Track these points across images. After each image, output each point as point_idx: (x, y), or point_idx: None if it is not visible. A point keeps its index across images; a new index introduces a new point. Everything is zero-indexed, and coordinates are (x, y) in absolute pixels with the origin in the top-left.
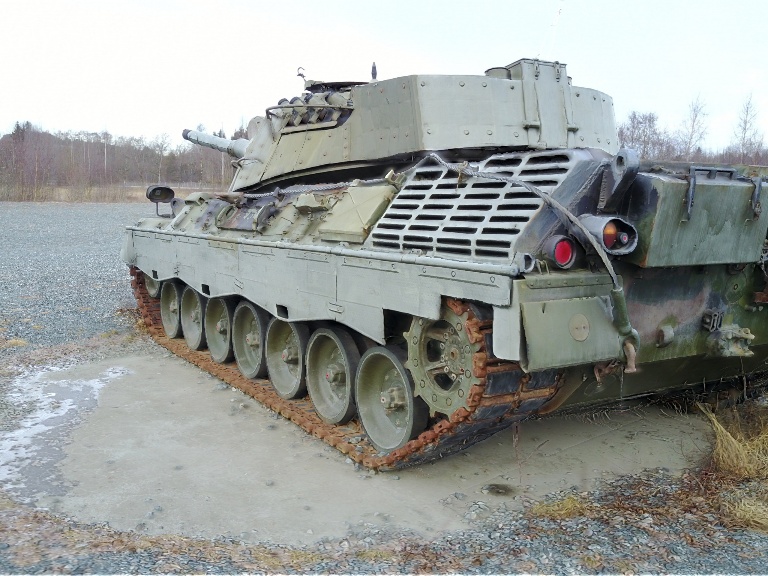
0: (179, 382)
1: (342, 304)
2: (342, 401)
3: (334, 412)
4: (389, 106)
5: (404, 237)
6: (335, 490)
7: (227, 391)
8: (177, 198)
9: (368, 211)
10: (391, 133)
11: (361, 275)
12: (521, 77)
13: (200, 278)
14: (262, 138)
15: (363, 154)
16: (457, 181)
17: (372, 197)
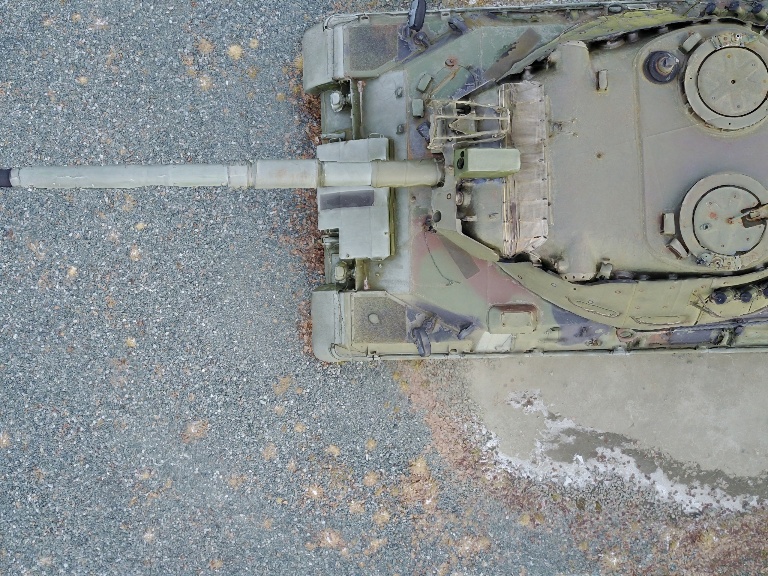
0: (588, 368)
1: None
2: None
3: None
4: None
5: None
6: None
7: None
8: None
9: None
10: None
11: None
12: None
13: None
14: None
15: None
16: None
17: None
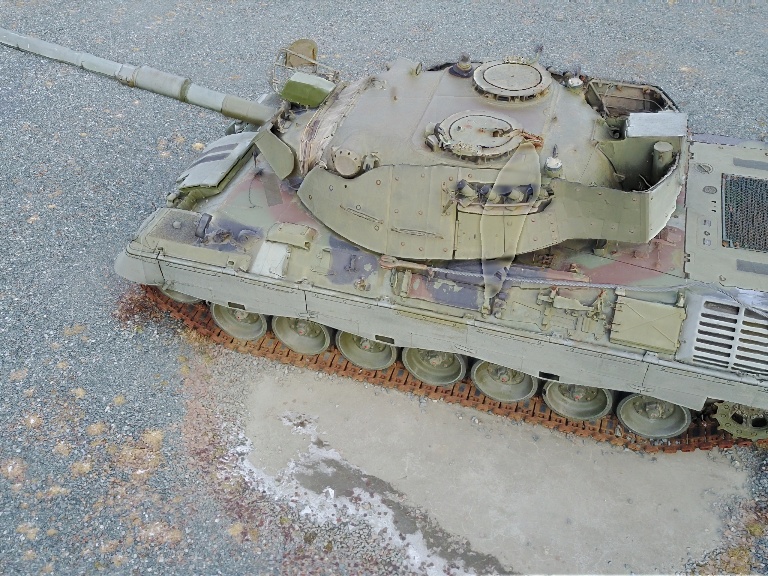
0: (377, 411)
1: (652, 388)
2: (579, 403)
3: (574, 411)
4: (608, 206)
5: (735, 364)
6: (661, 484)
7: (432, 405)
8: (245, 234)
9: (671, 331)
10: (608, 224)
11: (684, 379)
12: (679, 148)
13: (373, 331)
14: (412, 201)
15: (572, 235)
16: (766, 323)
17: (665, 316)
